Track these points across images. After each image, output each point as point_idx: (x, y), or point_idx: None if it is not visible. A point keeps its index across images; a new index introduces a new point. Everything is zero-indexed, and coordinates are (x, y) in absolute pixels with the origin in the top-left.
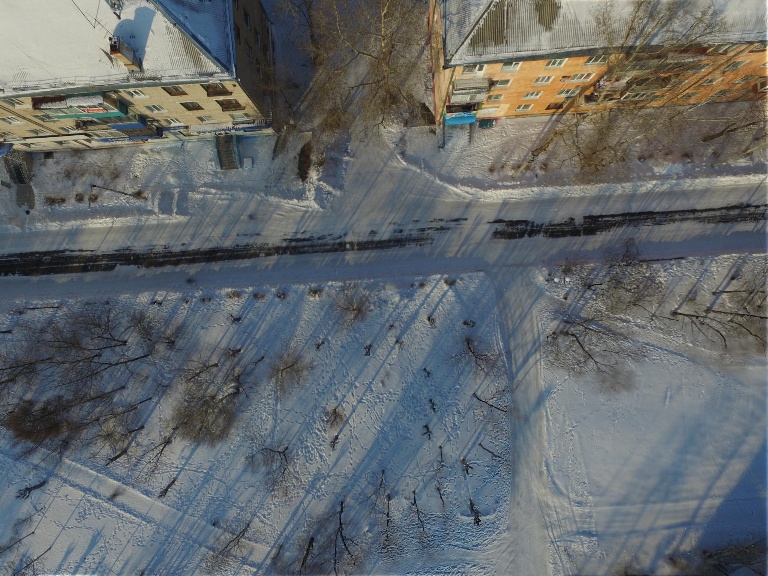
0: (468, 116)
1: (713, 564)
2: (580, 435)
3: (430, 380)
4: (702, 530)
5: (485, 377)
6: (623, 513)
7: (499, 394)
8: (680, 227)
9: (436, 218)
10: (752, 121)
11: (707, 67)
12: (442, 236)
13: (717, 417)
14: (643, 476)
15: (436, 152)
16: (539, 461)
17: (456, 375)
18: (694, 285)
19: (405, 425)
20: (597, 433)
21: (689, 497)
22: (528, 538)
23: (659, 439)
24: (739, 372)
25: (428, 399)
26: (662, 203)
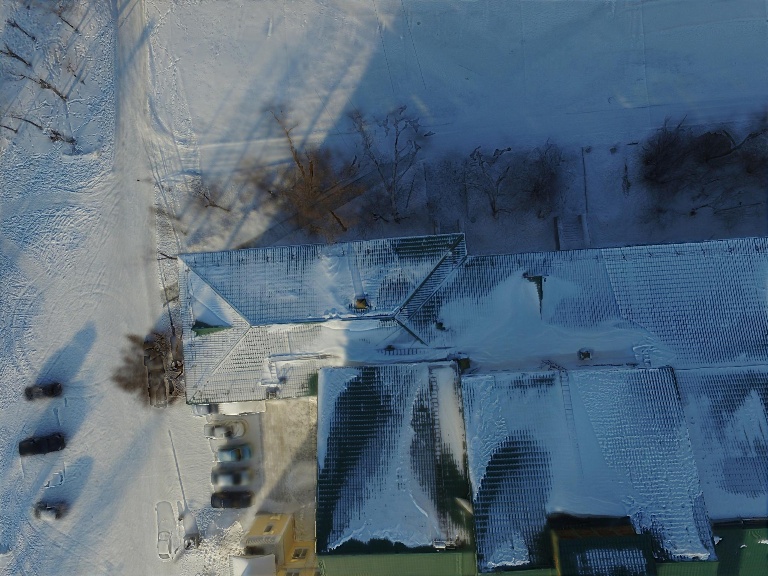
0: None
1: None
2: (182, 70)
3: (32, 17)
4: (306, 166)
5: (86, 12)
6: (228, 151)
7: (102, 30)
8: None
9: None
10: None
11: None
12: None
13: (319, 47)
14: (246, 111)
15: None
16: (143, 99)
17: None
18: None
19: (8, 65)
20: (199, 67)
21: (293, 132)
22: (134, 180)
23: (261, 71)
24: (343, 1)
25: (31, 37)
26: None
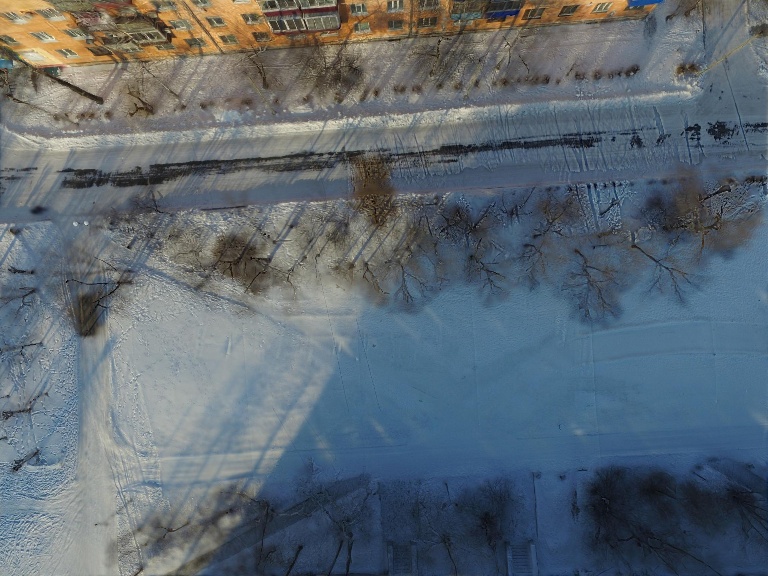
0: (0, 60)
1: (265, 514)
2: (143, 385)
3: None
4: (264, 481)
5: (51, 326)
6: (188, 464)
7: (65, 343)
8: (245, 176)
9: (7, 167)
10: (313, 68)
11: (171, 2)
12: (13, 185)
13: (277, 367)
14: (205, 426)
15: (6, 101)
16: (106, 411)
17: (24, 324)
18: (254, 234)
19: None
20: (160, 383)
21: (251, 448)
22: (96, 488)
23: (220, 389)
24: (300, 322)
25: None
26: (227, 151)
